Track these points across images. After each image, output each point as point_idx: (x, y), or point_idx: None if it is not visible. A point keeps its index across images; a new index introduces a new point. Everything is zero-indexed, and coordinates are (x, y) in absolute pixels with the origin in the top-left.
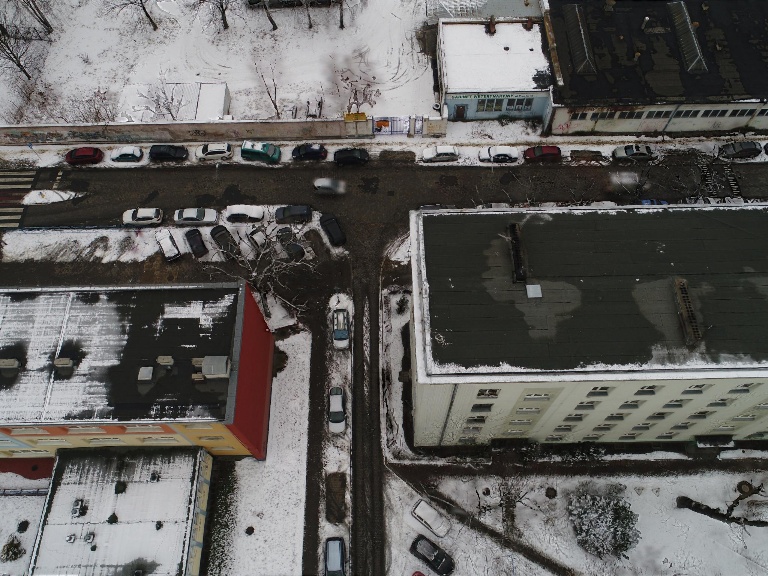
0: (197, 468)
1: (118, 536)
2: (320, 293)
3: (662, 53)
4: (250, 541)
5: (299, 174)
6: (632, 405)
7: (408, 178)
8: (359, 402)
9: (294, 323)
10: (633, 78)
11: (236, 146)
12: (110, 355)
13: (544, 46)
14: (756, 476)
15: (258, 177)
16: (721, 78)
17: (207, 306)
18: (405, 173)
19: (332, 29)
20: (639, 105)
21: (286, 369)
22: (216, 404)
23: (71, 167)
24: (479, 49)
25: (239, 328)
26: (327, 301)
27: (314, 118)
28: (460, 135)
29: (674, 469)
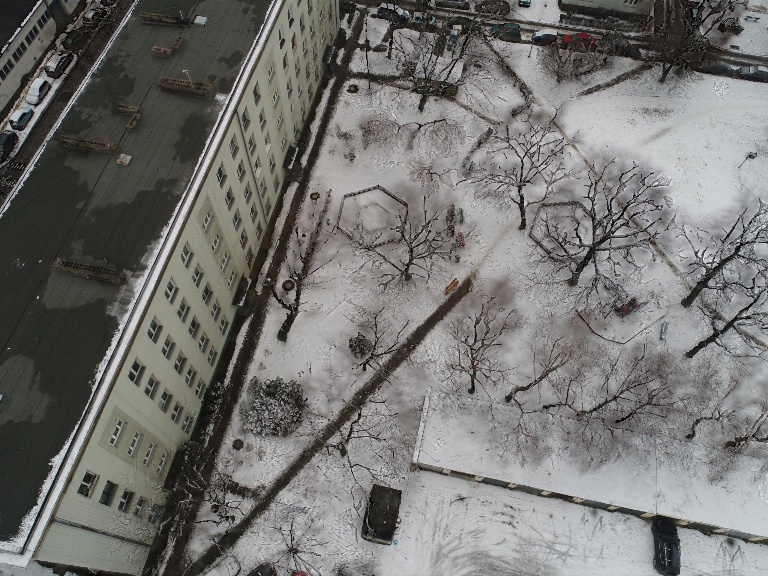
0: None
1: None
2: None
3: None
4: None
5: None
6: (171, 347)
7: None
8: None
9: None
10: None
11: None
12: None
13: None
14: (282, 274)
15: None
16: None
17: None
18: None
19: None
20: None
21: None
22: None
23: None
24: None
25: None
26: None
27: None
28: None
29: (256, 331)
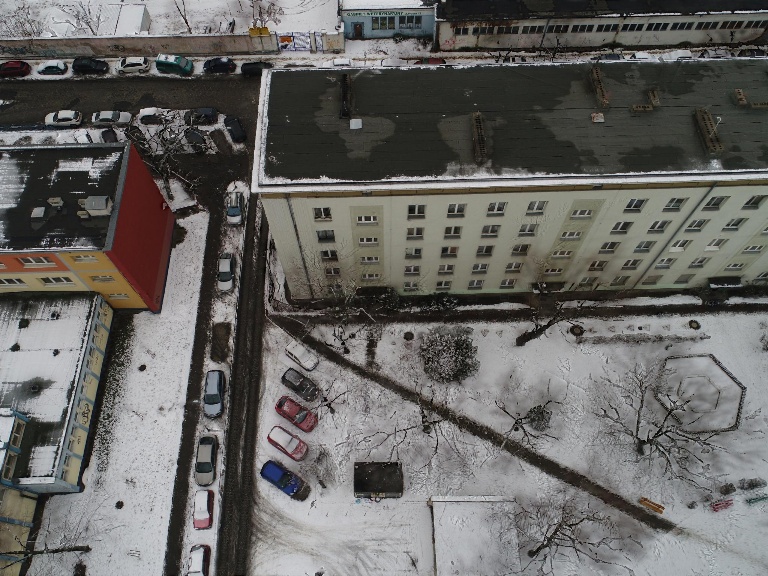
0: (93, 309)
1: (19, 360)
2: (220, 181)
3: None
4: (142, 376)
5: (209, 84)
6: (455, 236)
7: None
8: (248, 268)
9: (194, 204)
10: None
11: (153, 61)
12: (9, 200)
13: None
14: (587, 321)
15: (172, 87)
16: None
17: (96, 161)
18: None
19: None
20: (513, 19)
21: (184, 241)
22: (98, 236)
23: (1, 79)
24: None
25: (122, 177)
26: (226, 187)
27: (222, 33)
28: (358, 51)
29: (517, 316)
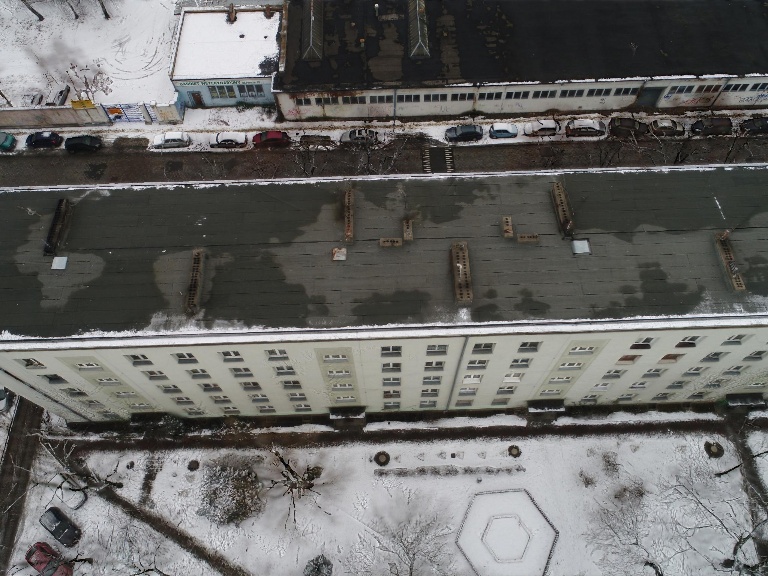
0: None
1: None
2: None
3: (390, 39)
4: None
5: (30, 161)
6: (205, 375)
7: (135, 164)
8: None
9: None
10: (356, 64)
11: None
12: None
13: (279, 33)
14: (395, 446)
15: None
16: (441, 63)
17: None
18: (134, 159)
19: (98, 19)
20: (356, 90)
21: None
22: None
23: None
24: (215, 37)
25: None
26: None
27: (42, 106)
28: (197, 122)
29: (318, 441)
